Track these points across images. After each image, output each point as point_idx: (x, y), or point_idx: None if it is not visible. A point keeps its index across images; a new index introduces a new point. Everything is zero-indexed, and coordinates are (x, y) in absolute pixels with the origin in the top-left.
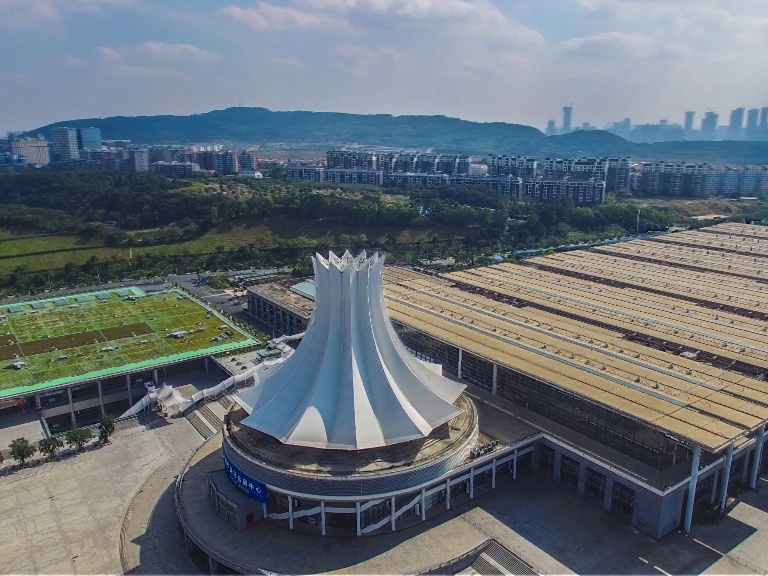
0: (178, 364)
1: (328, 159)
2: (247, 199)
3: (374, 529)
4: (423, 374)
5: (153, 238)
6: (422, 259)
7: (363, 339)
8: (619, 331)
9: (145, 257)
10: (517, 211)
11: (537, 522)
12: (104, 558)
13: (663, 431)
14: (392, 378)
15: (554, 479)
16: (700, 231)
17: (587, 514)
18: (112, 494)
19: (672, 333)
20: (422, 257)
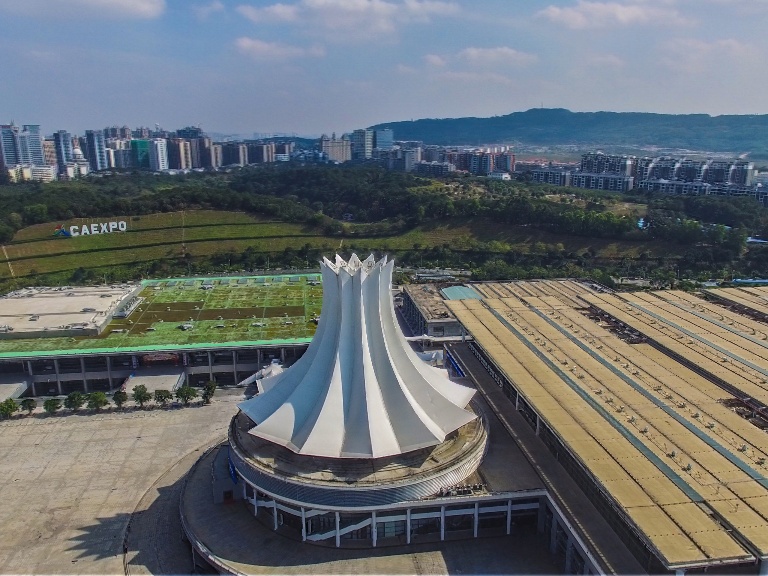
0: (302, 347)
1: (582, 162)
2: None
3: (320, 539)
4: (427, 394)
5: (364, 231)
6: (621, 277)
7: (355, 346)
8: (731, 391)
9: (350, 248)
10: None
11: None
12: (131, 496)
13: (629, 523)
14: (379, 391)
15: (551, 548)
16: None
17: None
18: (178, 446)
19: None
20: (622, 275)
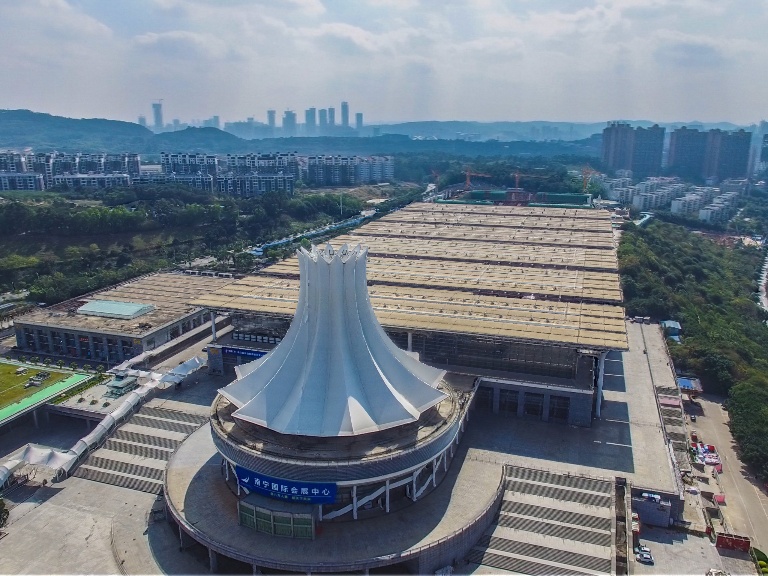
0: None
1: None
2: None
3: (423, 491)
4: None
5: None
6: None
7: (363, 325)
8: (466, 291)
9: None
10: None
11: (517, 443)
12: None
13: (589, 347)
14: None
15: (494, 412)
16: (405, 211)
17: (538, 427)
18: None
19: (501, 285)
20: None
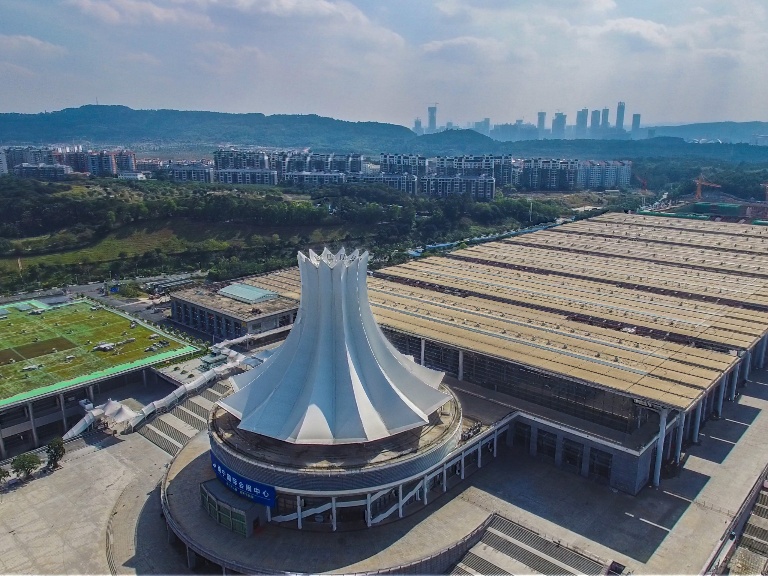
0: (115, 378)
1: (216, 159)
2: None
3: (383, 518)
4: (406, 365)
5: (44, 247)
6: None
7: (354, 334)
8: (561, 313)
9: (38, 267)
10: (420, 207)
11: (529, 493)
12: None
13: (637, 397)
14: (383, 370)
15: (531, 453)
16: (590, 221)
17: (569, 481)
18: (82, 520)
19: (607, 312)
20: None
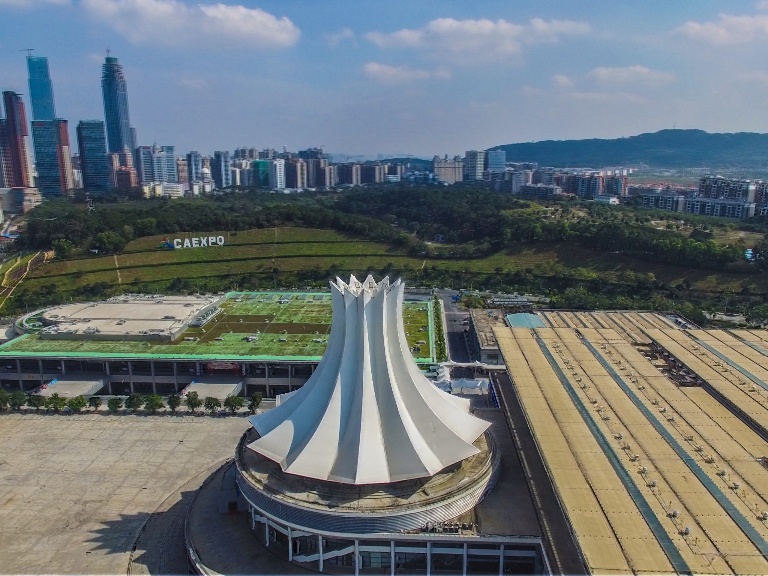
0: None
1: (700, 187)
2: (547, 224)
3: (305, 561)
4: (430, 423)
5: (447, 253)
6: (717, 312)
7: (358, 368)
8: None
9: (431, 269)
10: None
11: None
12: (156, 497)
13: None
14: (378, 416)
15: None
16: None
17: None
18: (213, 453)
19: None
20: (719, 310)
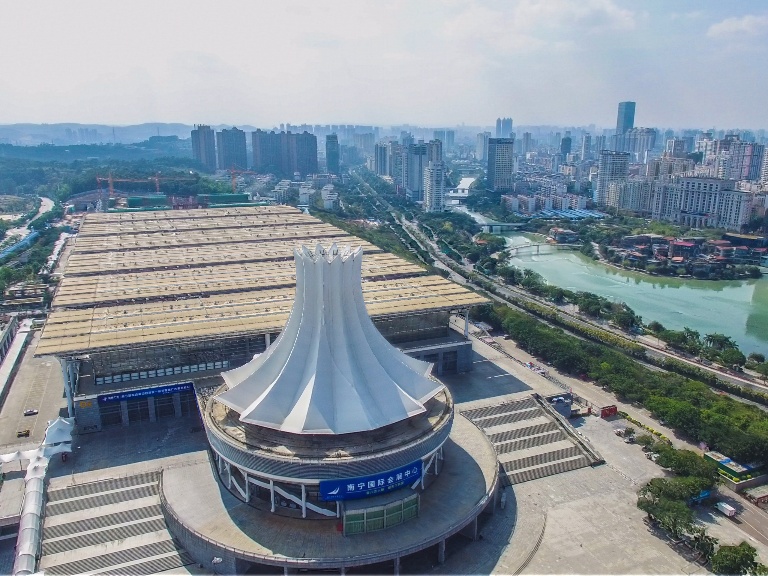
0: None
1: None
2: None
3: None
4: None
5: None
6: None
7: None
8: None
9: None
10: None
11: None
12: None
13: (468, 306)
14: None
15: None
16: None
17: (442, 381)
18: None
19: None
20: None
